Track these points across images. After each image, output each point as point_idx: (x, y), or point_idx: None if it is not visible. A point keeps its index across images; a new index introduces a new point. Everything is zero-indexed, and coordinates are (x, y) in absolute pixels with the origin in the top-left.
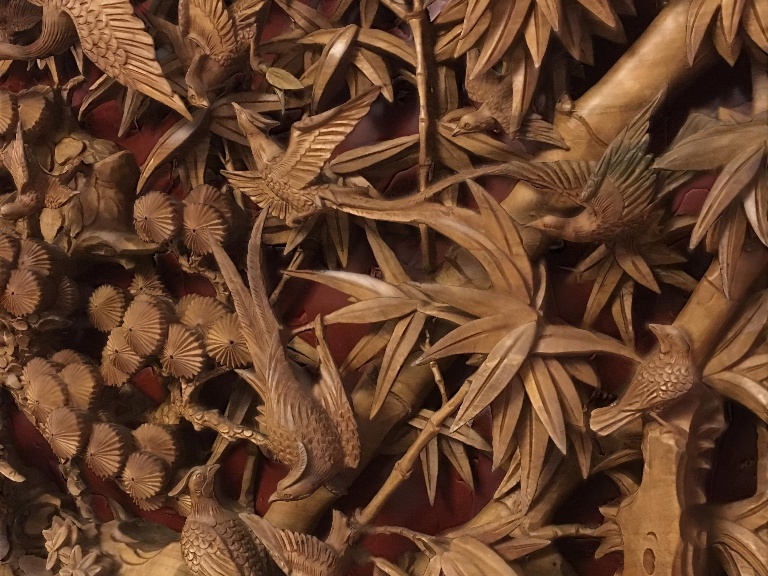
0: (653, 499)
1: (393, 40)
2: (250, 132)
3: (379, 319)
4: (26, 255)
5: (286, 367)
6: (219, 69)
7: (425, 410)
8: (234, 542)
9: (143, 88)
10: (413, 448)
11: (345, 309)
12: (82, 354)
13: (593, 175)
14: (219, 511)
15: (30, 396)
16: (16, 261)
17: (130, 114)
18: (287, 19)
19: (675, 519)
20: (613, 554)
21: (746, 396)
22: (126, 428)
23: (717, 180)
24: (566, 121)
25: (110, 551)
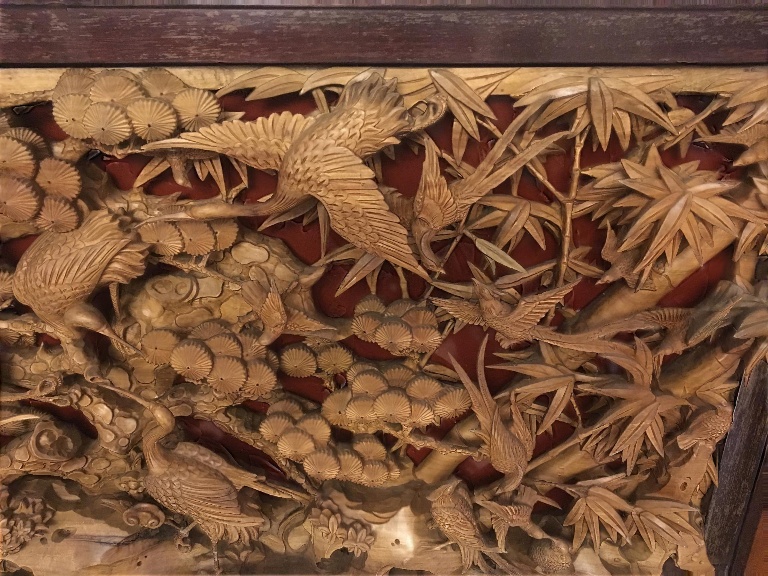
0: (694, 466)
1: (549, 211)
2: (488, 299)
3: (552, 390)
4: (249, 349)
5: (502, 425)
6: (435, 234)
7: (533, 404)
8: (466, 511)
9: (389, 258)
10: (564, 448)
11: (531, 386)
12: (291, 399)
13: (699, 334)
14: (453, 497)
15: (285, 447)
16: (242, 354)
17: (326, 239)
18: (448, 168)
19: (703, 473)
20: (635, 464)
21: (716, 402)
22: (347, 445)
23: (762, 345)
24: (659, 277)
25: (354, 517)
